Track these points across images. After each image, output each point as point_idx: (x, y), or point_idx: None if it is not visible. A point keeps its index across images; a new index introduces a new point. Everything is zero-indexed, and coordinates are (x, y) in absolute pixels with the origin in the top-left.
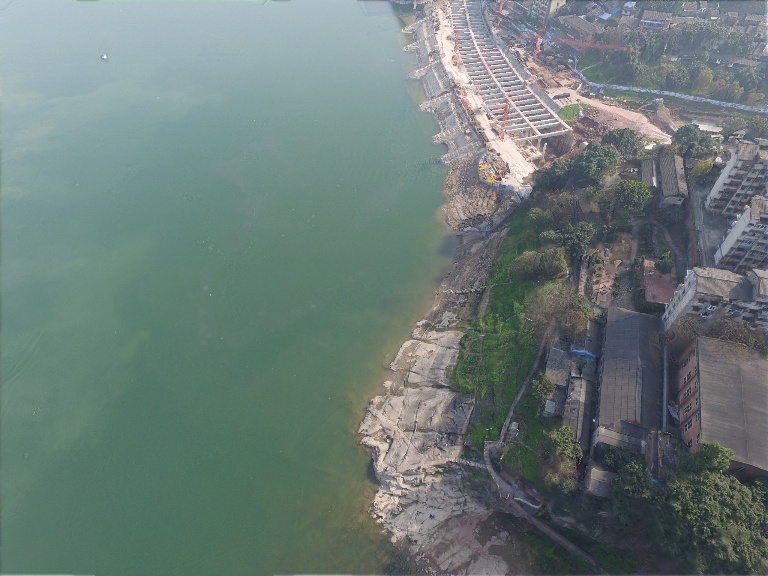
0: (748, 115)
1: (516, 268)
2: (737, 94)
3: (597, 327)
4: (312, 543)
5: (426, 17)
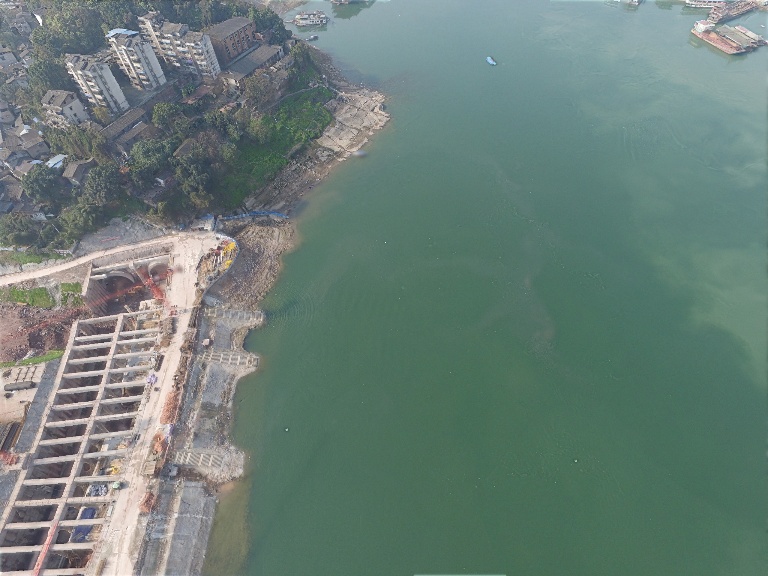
0: None
1: (268, 128)
2: None
3: None
4: (413, 92)
5: None
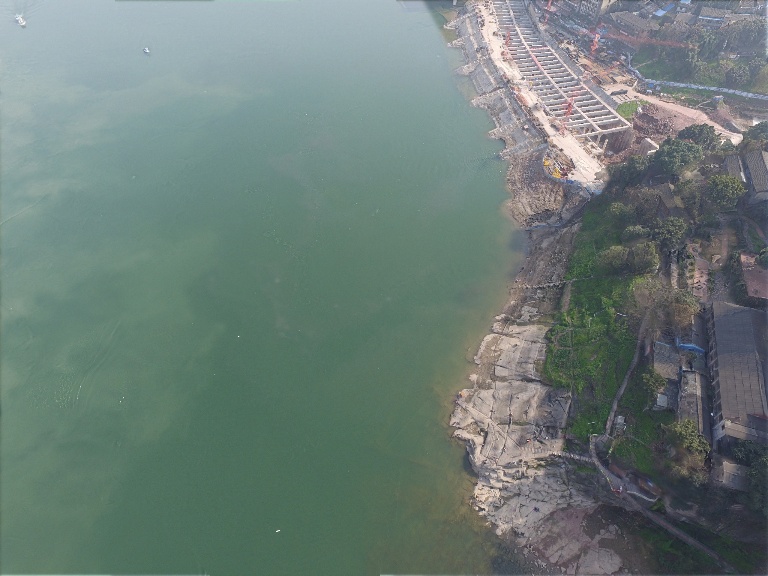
0: None
1: (603, 263)
2: None
3: (701, 321)
4: (416, 534)
5: (469, 13)
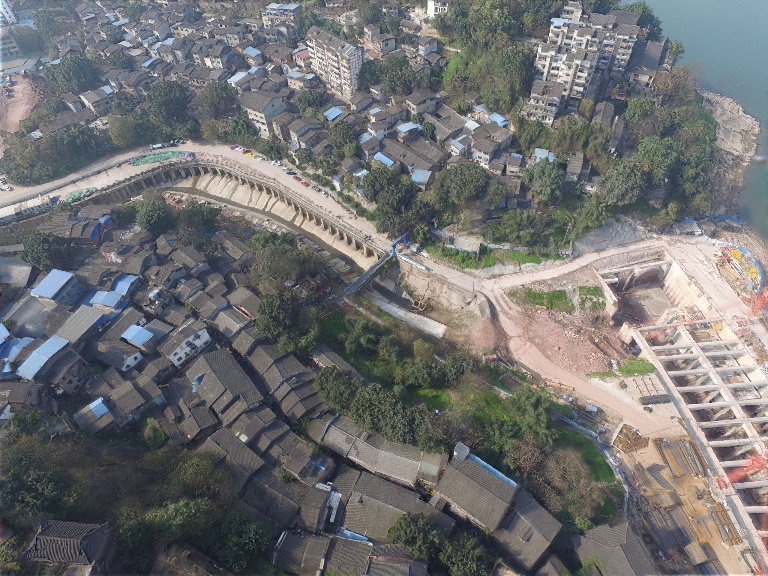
0: None
1: None
2: None
3: None
4: (758, 96)
5: None
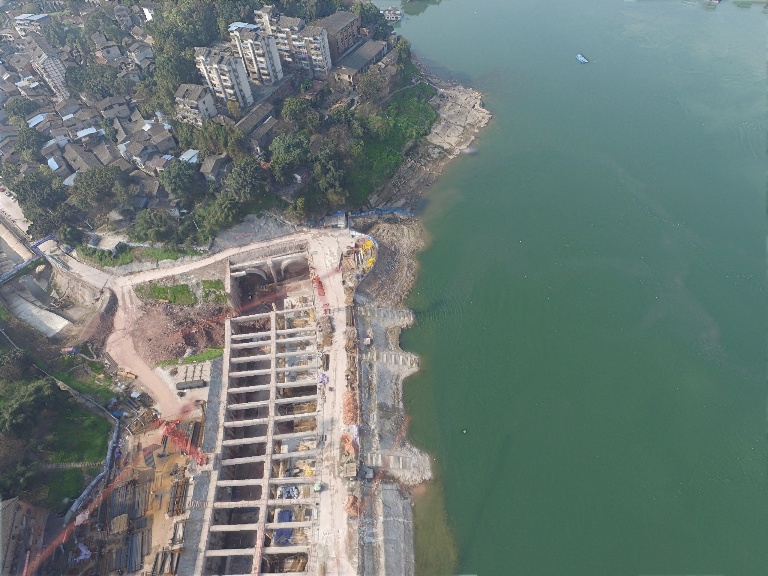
0: None
1: None
2: None
3: None
4: None
5: None
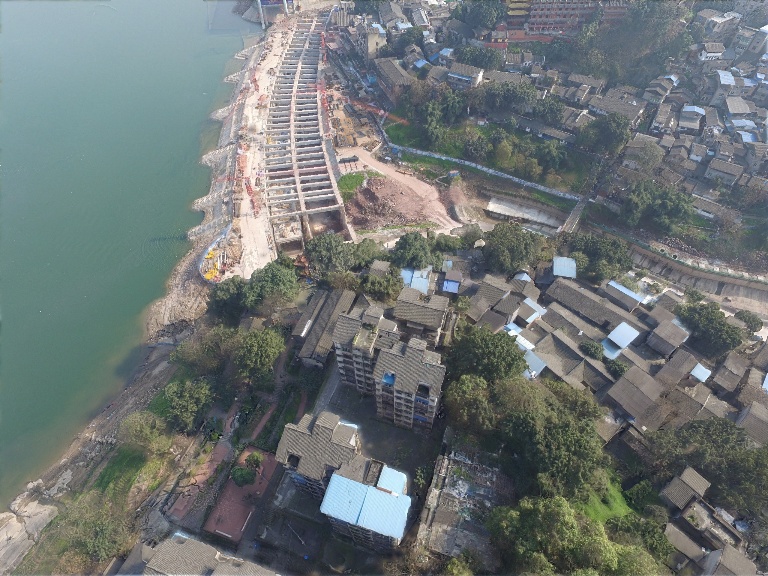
0: (547, 198)
1: (117, 436)
2: (535, 173)
3: None
4: None
5: (263, 41)
